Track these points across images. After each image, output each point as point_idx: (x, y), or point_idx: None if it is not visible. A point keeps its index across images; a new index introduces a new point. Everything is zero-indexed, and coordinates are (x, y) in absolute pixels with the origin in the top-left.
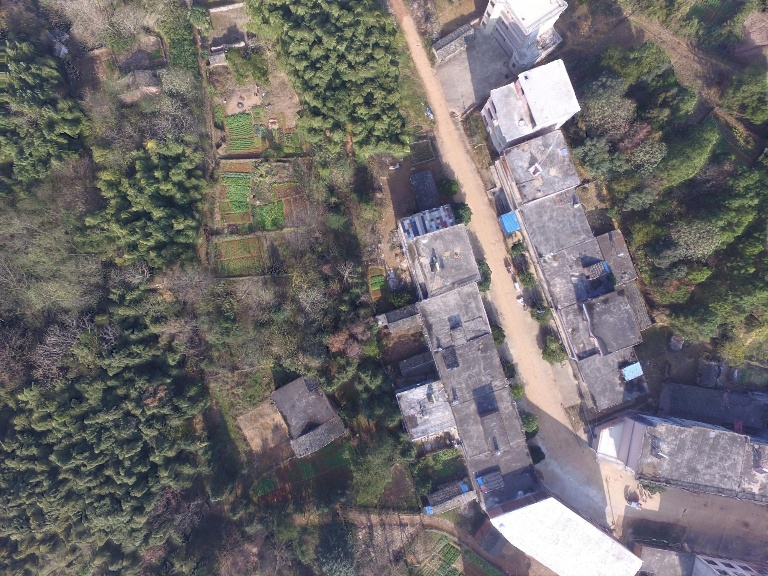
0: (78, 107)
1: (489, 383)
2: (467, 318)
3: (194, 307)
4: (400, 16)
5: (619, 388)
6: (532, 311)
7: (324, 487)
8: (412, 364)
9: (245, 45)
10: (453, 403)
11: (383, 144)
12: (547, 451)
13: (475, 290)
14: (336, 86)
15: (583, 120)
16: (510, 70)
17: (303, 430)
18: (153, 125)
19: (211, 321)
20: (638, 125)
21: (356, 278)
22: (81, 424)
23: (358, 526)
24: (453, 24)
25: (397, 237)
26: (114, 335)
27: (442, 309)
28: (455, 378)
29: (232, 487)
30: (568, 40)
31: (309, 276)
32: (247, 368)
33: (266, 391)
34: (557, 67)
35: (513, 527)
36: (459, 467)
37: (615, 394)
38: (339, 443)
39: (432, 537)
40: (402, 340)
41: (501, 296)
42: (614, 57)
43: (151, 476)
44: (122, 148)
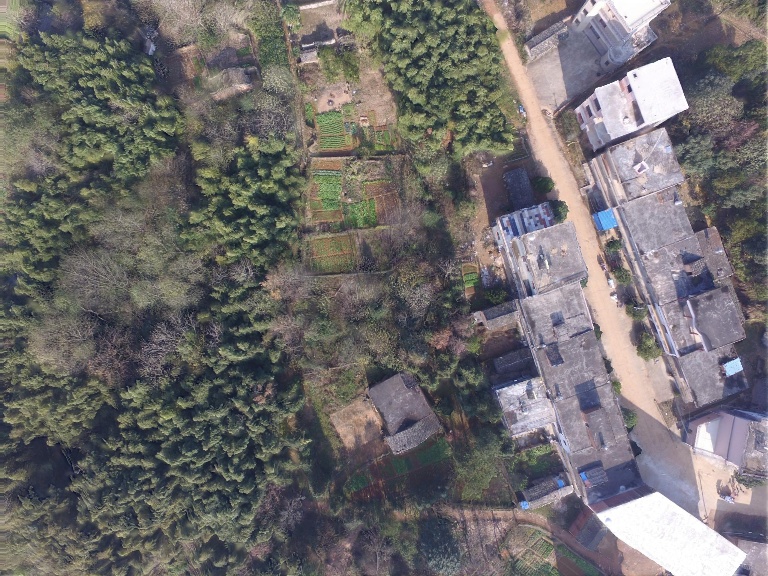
0: (174, 105)
1: (591, 379)
2: (569, 315)
3: (292, 305)
4: (491, 14)
5: (719, 384)
6: (628, 308)
7: (419, 483)
8: (509, 361)
9: (335, 42)
10: (556, 399)
11: (485, 142)
12: (641, 446)
13: (577, 287)
14: (438, 84)
15: (688, 118)
16: (602, 68)
17: (400, 427)
18: (254, 123)
19: (307, 319)
20: (745, 123)
21: (459, 275)
22: (188, 422)
23: (451, 521)
24: (544, 22)
25: (490, 234)
26: (219, 333)
27: (545, 306)
28: (558, 374)
29: (330, 484)
30: (659, 38)
31: (417, 274)
32: (341, 365)
33: (359, 388)
34: (665, 65)
35: (619, 521)
36: (553, 462)
37: (715, 389)
38: (432, 439)
39: (525, 532)
40: (496, 337)
41: (595, 293)
42: (719, 55)
43: (258, 473)
44: (223, 146)
